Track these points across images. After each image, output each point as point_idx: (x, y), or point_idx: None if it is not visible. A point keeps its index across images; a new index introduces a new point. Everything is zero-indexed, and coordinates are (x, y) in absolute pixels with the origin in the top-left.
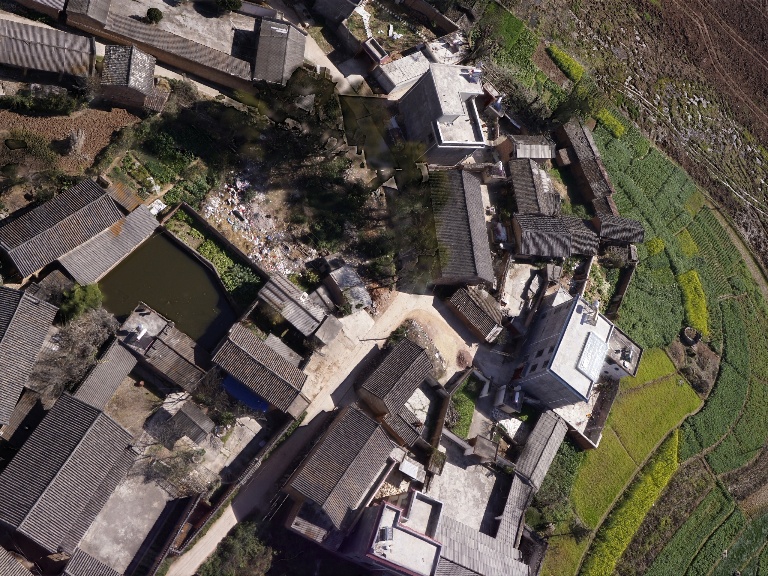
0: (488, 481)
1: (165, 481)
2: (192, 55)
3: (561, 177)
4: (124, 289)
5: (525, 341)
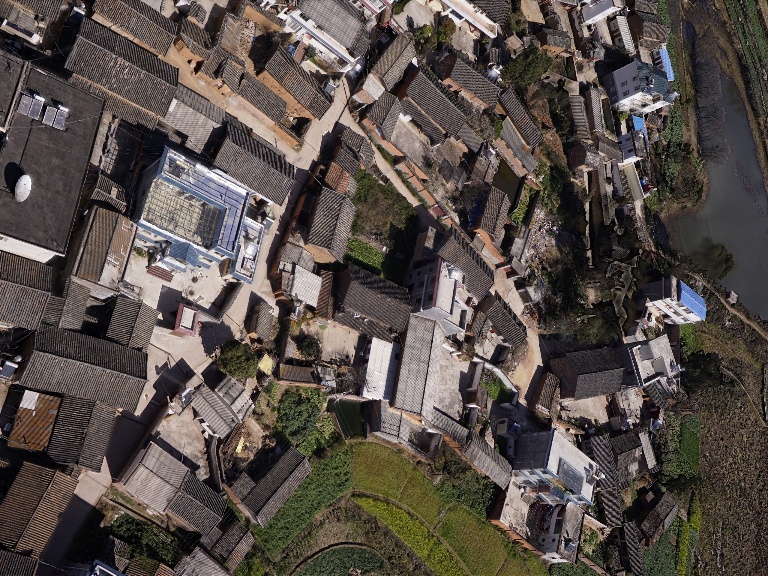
0: (455, 412)
1: (424, 167)
2: (603, 197)
3: (635, 500)
4: None
5: None
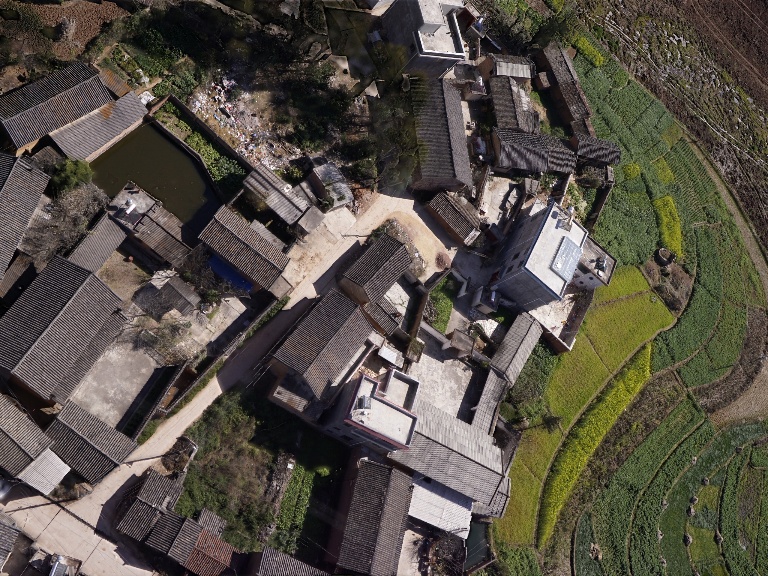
0: (465, 375)
1: (153, 350)
2: None
3: (541, 100)
4: (114, 175)
5: (502, 248)
